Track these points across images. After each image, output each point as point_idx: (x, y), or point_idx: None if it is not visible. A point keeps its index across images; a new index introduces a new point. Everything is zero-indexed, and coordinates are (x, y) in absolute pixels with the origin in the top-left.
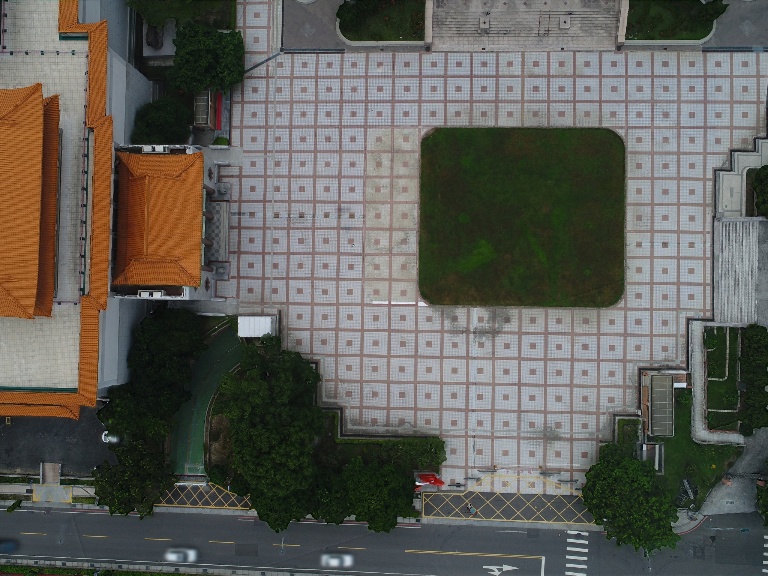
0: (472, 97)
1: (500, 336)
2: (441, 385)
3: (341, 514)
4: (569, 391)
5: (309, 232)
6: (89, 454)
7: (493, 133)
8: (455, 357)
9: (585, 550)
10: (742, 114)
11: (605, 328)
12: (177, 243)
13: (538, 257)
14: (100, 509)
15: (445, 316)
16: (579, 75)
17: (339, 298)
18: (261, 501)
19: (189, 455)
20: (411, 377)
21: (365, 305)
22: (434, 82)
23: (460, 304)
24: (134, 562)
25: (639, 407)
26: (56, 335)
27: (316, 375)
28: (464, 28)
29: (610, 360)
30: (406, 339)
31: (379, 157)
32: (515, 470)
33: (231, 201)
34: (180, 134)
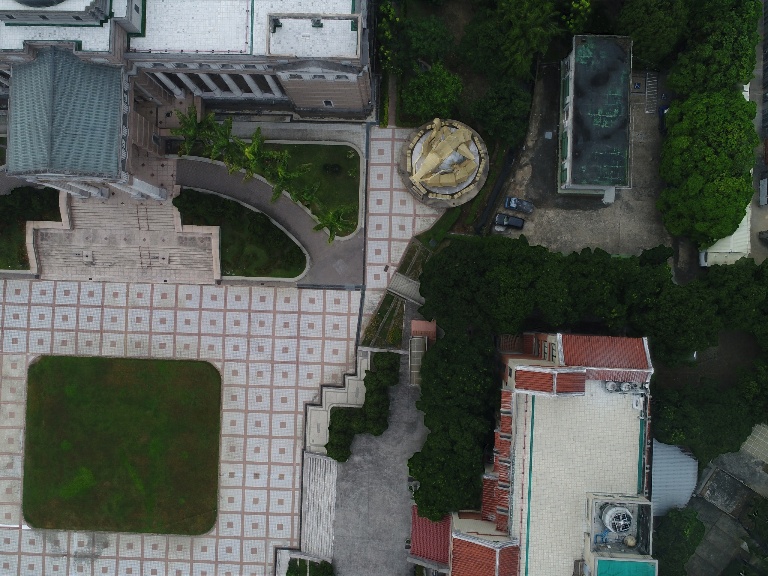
0: (78, 326)
1: (99, 560)
2: None
3: None
4: None
5: None
6: None
7: (96, 362)
8: None
9: None
10: (333, 351)
11: (197, 555)
12: None
13: (135, 485)
14: None
15: (47, 539)
16: (180, 308)
17: None
18: None
19: None
20: None
21: None
22: (42, 310)
23: (61, 528)
24: None
25: None
26: None
27: None
28: (70, 259)
29: None
30: (9, 561)
31: None
32: None
33: None
34: None
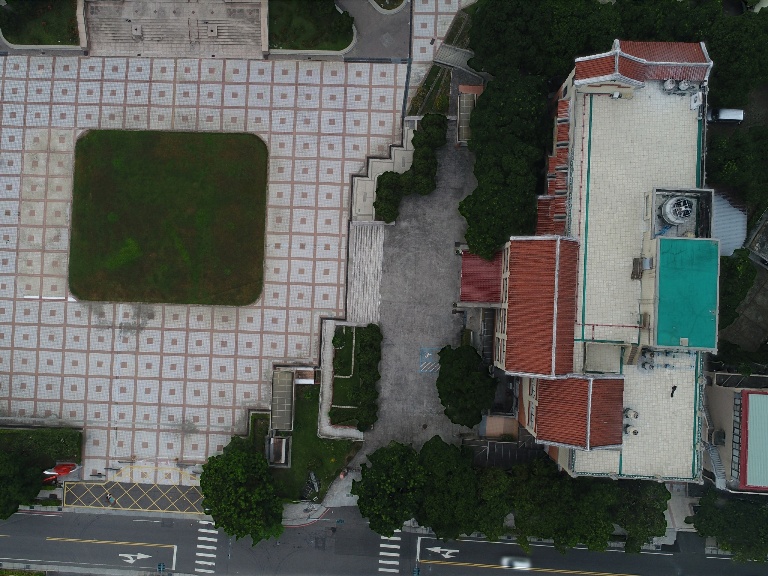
0: (126, 101)
1: (144, 332)
2: (86, 378)
3: None
4: (207, 386)
5: None
6: None
7: (144, 136)
8: (101, 351)
9: (215, 540)
10: (379, 122)
11: (243, 326)
12: None
13: (182, 256)
14: None
15: (93, 311)
16: (228, 82)
17: None
18: None
19: None
20: (58, 370)
21: (17, 299)
22: (91, 85)
23: (107, 300)
24: None
25: None
26: None
27: None
28: (119, 34)
29: (247, 356)
30: (55, 333)
31: (36, 157)
32: (153, 461)
33: None
34: None
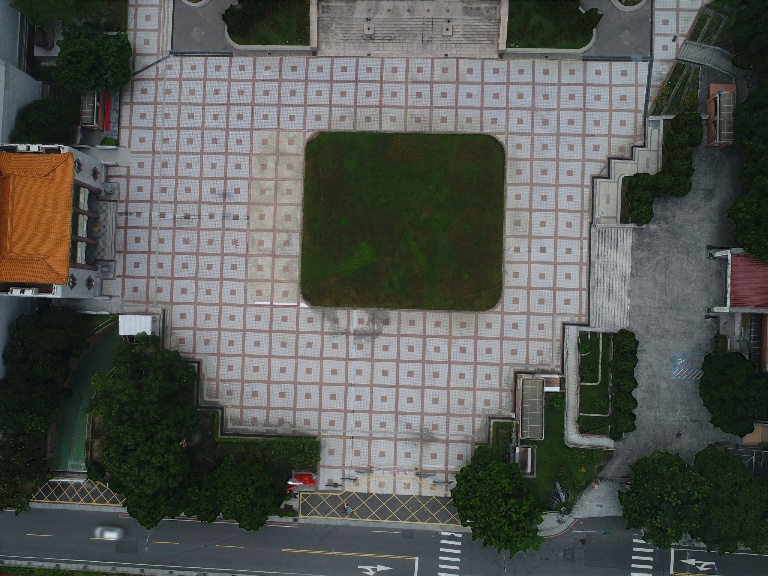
0: (356, 102)
1: (379, 338)
2: (320, 386)
3: (213, 512)
4: (446, 393)
5: (194, 233)
6: None
7: (376, 137)
8: (335, 358)
9: (458, 551)
10: (620, 122)
11: (482, 332)
12: (44, 241)
13: (418, 260)
14: None
15: (326, 317)
16: (462, 82)
17: (222, 298)
18: (130, 498)
19: (73, 452)
20: (291, 377)
21: (247, 305)
22: (320, 86)
23: (341, 306)
24: (16, 557)
25: (514, 410)
26: None
27: (193, 374)
28: (349, 34)
29: (487, 363)
30: (287, 340)
31: (264, 159)
32: (391, 471)
33: (118, 201)
34: (62, 134)
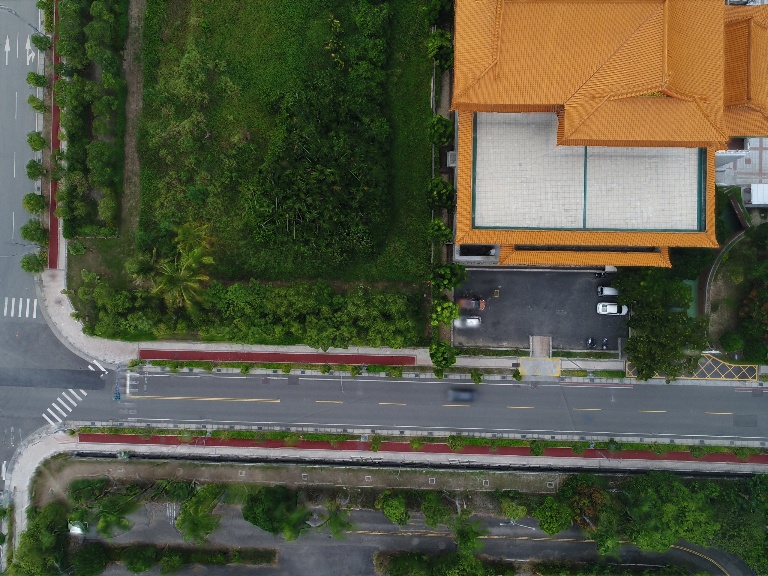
0: None
1: None
2: None
3: None
4: None
5: None
6: (580, 327)
7: None
8: None
9: None
10: None
11: None
12: (762, 92)
13: None
14: (590, 382)
15: None
16: None
17: None
18: None
19: None
20: None
21: None
22: None
23: None
24: (627, 434)
25: None
26: (672, 176)
27: None
28: None
29: None
30: None
31: None
32: None
33: None
34: None
